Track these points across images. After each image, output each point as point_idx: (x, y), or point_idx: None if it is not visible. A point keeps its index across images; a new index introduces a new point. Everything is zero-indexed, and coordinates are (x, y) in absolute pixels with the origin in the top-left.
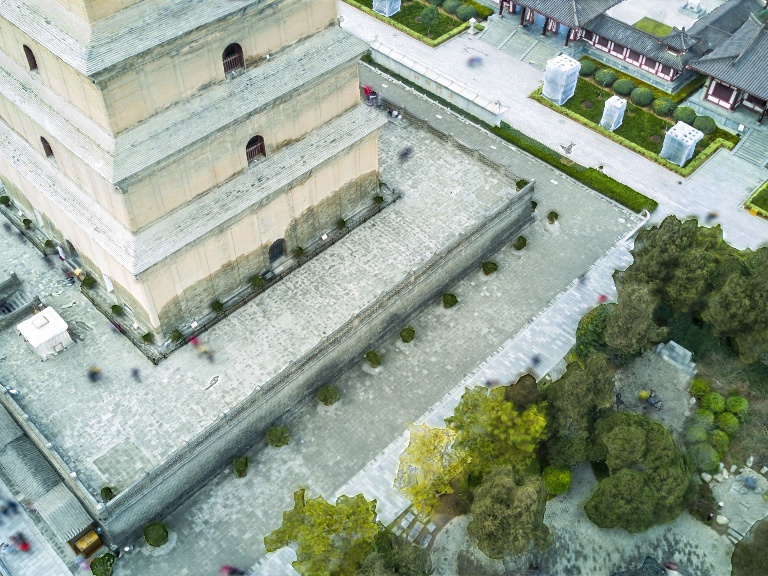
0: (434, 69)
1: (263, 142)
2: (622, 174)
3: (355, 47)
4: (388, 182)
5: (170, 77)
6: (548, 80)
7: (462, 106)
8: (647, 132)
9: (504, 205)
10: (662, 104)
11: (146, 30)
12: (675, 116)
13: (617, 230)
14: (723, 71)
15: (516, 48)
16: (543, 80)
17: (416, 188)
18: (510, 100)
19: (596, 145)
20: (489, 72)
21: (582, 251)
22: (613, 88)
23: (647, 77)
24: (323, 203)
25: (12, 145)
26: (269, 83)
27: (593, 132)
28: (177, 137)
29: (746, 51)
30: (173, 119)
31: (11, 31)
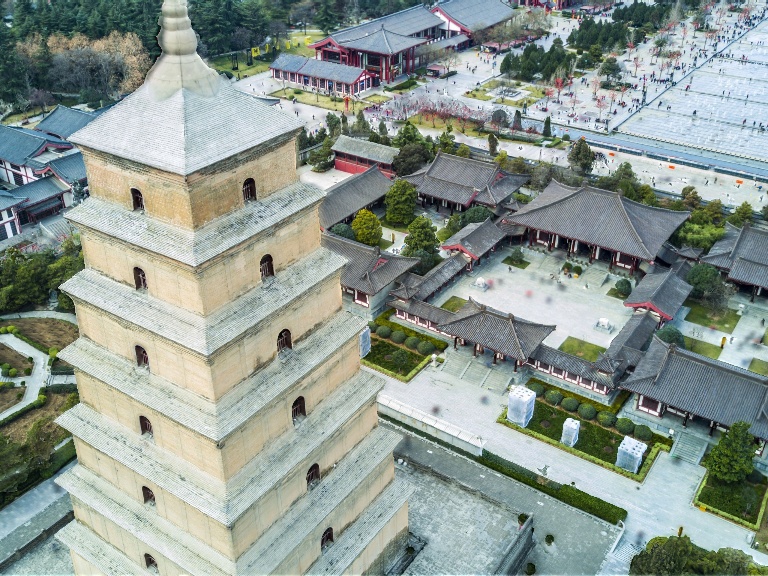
0: (418, 410)
1: (332, 531)
2: (590, 486)
3: (393, 441)
4: (412, 530)
5: (274, 504)
6: (511, 408)
7: (447, 440)
8: (600, 444)
9: (515, 541)
10: (605, 418)
11: (263, 477)
12: (618, 427)
13: (603, 543)
14: (648, 389)
15: (475, 377)
16: (504, 404)
17: (437, 532)
18: (482, 426)
19: (562, 461)
20: (458, 401)
21: (581, 568)
22: (562, 406)
23: (586, 393)
24: (372, 566)
25: (108, 557)
26: (338, 487)
27: (557, 449)
28: (280, 550)
29: (661, 371)
30: (275, 535)
31: (132, 476)
